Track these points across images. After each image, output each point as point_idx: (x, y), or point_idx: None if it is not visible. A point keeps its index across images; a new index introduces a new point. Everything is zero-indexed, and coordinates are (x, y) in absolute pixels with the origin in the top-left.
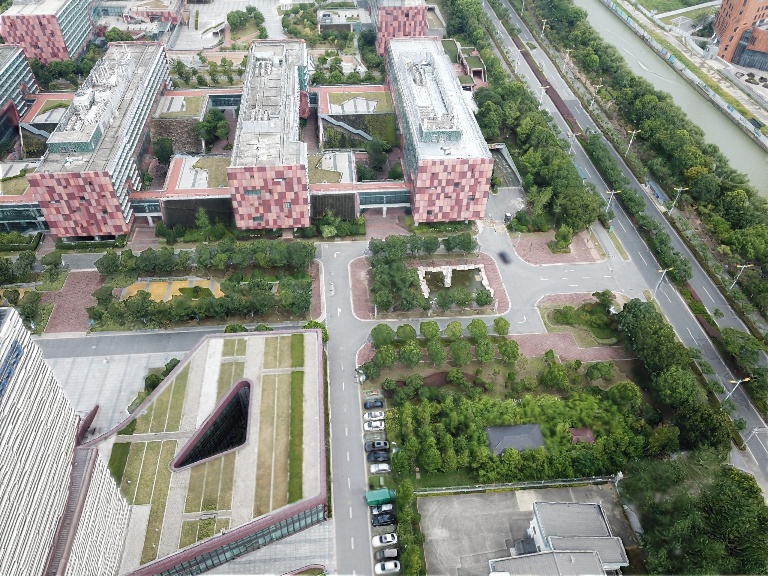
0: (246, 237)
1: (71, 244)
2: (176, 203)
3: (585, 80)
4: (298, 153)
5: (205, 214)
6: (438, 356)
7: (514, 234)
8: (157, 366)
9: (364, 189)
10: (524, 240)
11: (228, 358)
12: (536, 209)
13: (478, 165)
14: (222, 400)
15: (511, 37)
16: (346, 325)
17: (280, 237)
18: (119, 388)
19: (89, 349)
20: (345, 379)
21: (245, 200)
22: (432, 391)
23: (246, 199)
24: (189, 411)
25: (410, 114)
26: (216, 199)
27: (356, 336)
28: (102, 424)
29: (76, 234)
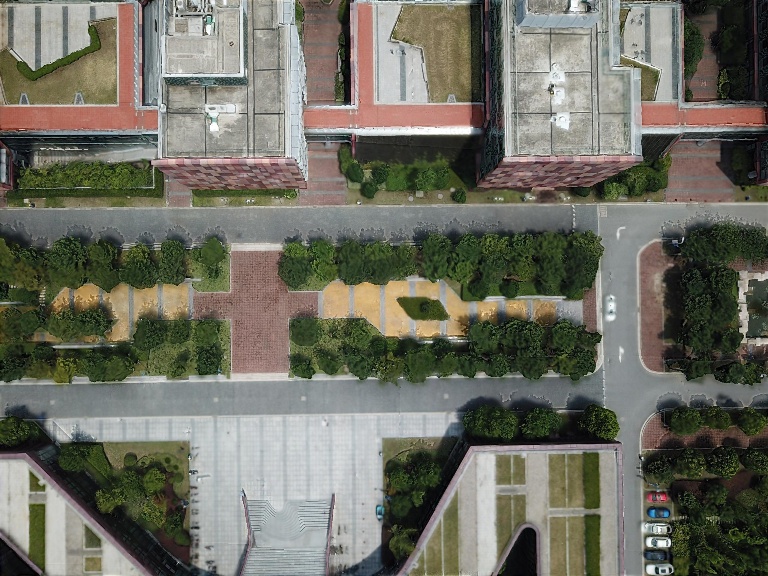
0: (483, 188)
1: (216, 192)
2: (379, 138)
3: None
4: (627, 109)
5: (422, 150)
6: (758, 474)
7: None
8: (391, 435)
9: (698, 126)
10: None
11: (504, 488)
12: None
13: None
14: (505, 555)
15: None
16: (630, 379)
17: (534, 187)
18: (352, 467)
19: (298, 402)
20: (625, 469)
21: (510, 176)
22: (737, 513)
23: (512, 176)
24: (467, 566)
25: None
26: (446, 135)
27: (642, 400)
28: (345, 519)
29: (226, 188)
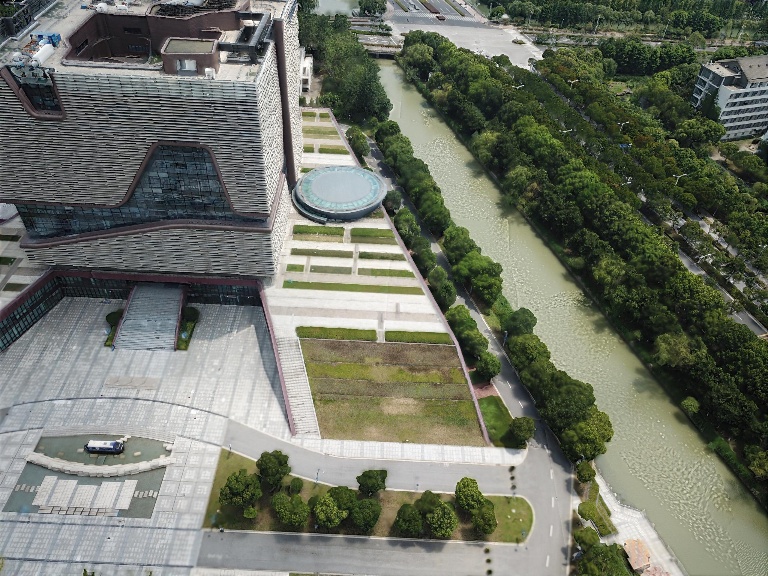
0: None
1: None
2: None
3: None
4: None
5: None
6: None
7: None
8: None
9: None
10: None
11: None
12: None
13: None
14: None
15: None
16: None
17: None
18: None
19: None
20: None
21: None
22: None
23: None
24: None
25: None
26: None
27: None
28: None
29: None
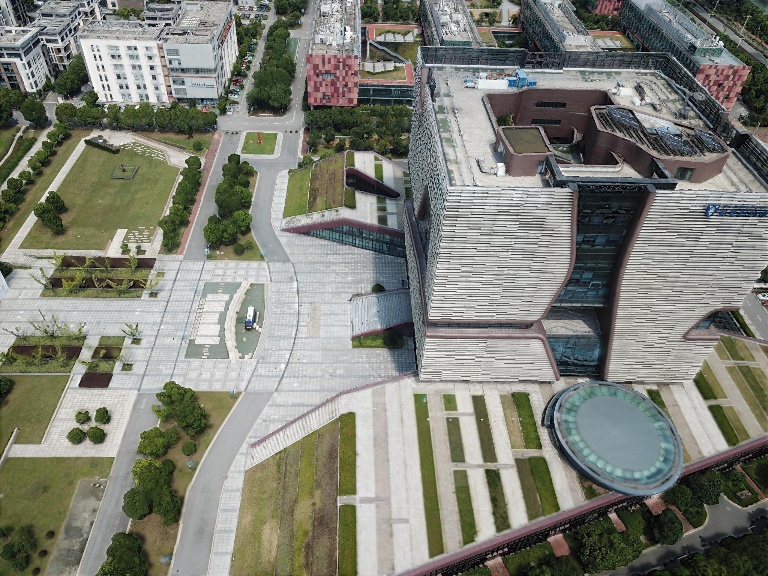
0: None
1: None
2: None
3: (761, 40)
4: None
5: None
6: None
7: (749, 127)
8: None
9: None
10: (757, 131)
11: None
12: (766, 110)
13: (739, 70)
14: None
15: (688, 9)
16: None
17: None
18: None
19: None
20: None
21: None
22: None
23: None
24: None
25: (674, 40)
26: None
27: None
28: None
29: None
